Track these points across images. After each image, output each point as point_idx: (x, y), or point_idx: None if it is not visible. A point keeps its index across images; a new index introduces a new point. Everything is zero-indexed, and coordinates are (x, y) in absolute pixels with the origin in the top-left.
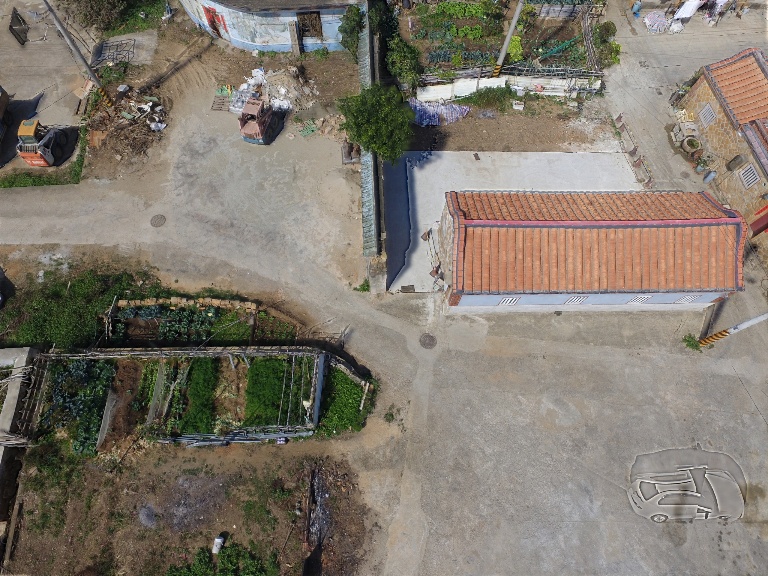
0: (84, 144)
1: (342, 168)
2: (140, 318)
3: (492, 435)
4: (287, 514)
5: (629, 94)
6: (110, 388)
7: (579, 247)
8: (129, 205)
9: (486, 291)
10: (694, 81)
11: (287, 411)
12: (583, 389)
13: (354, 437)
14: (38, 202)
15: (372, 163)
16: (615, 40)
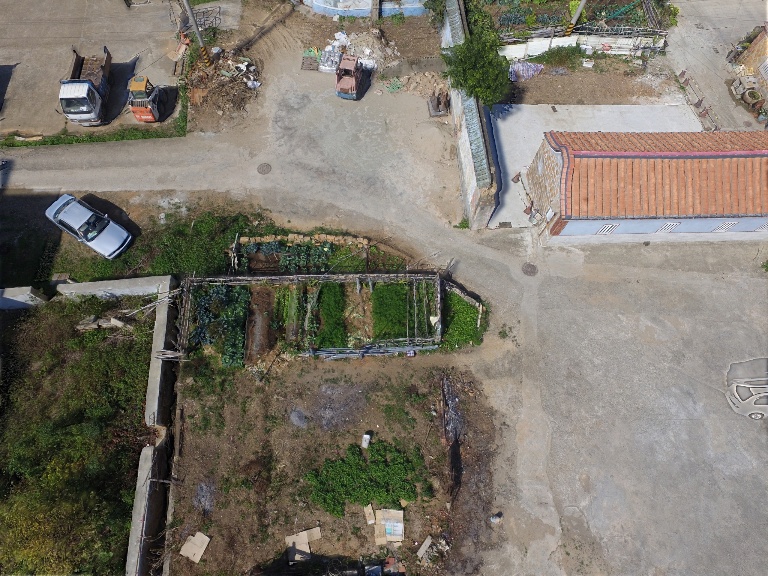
0: (185, 101)
1: (430, 120)
2: (262, 253)
3: (598, 348)
4: (424, 415)
5: (689, 53)
6: (248, 311)
7: (675, 176)
8: (235, 155)
9: (592, 216)
10: (748, 40)
11: (413, 328)
12: (676, 308)
13: (474, 351)
14: (150, 153)
15: (476, 106)
16: None
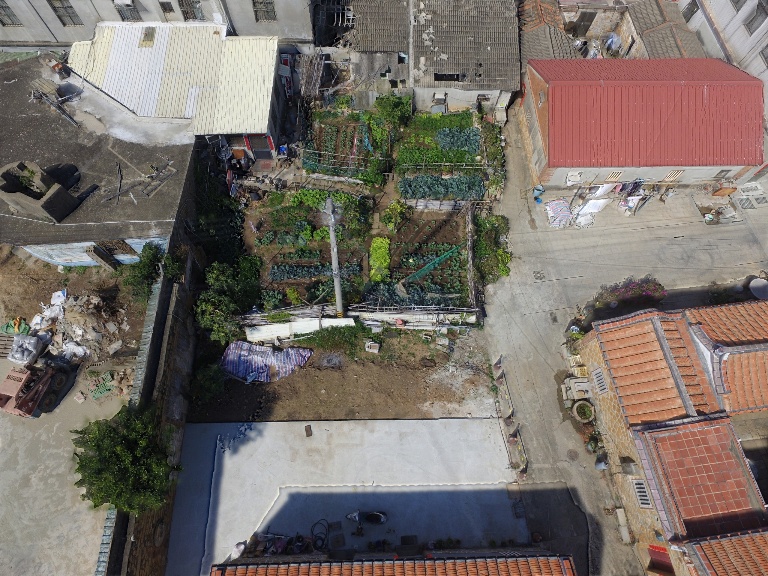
0: None
1: None
2: None
3: None
4: None
5: (516, 323)
6: None
7: None
8: None
9: None
10: None
11: None
12: None
13: None
14: None
15: (114, 525)
16: (508, 238)
